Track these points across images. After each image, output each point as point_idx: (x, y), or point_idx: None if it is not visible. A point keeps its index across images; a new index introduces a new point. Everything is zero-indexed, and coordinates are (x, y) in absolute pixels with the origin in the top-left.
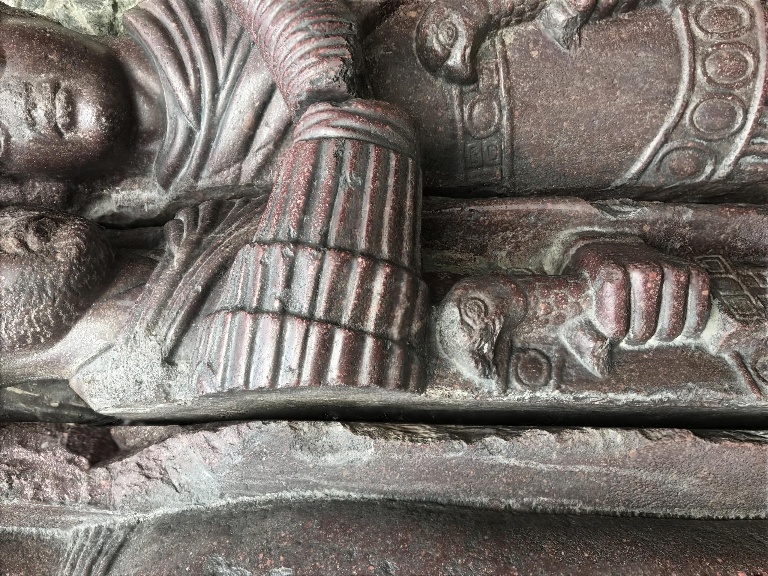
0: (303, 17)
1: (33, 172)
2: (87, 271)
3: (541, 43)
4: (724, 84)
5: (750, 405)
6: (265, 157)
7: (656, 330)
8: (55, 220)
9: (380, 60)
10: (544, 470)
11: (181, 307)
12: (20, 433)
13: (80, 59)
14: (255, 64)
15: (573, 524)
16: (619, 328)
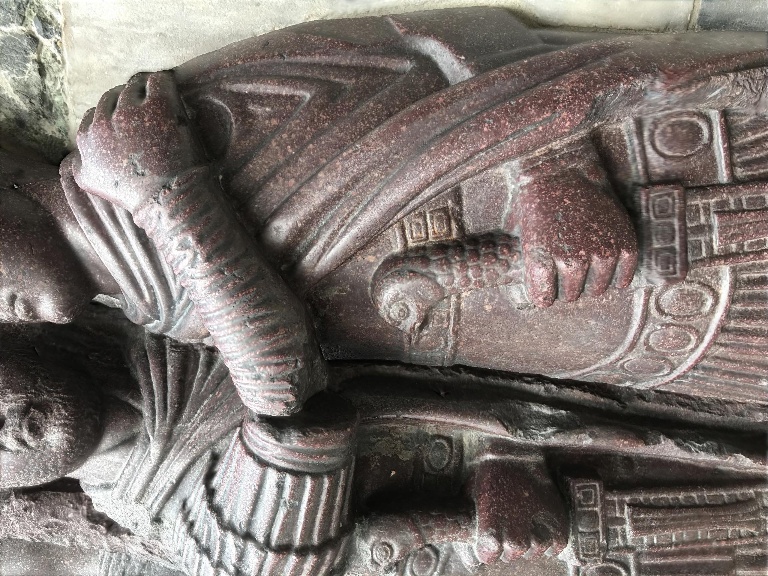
0: (249, 358)
1: None
2: (79, 449)
3: (497, 300)
4: (661, 352)
5: None
6: None
7: None
8: (42, 409)
9: (334, 299)
10: None
11: (161, 491)
12: (50, 506)
13: (29, 266)
14: None
15: None
16: (489, 563)
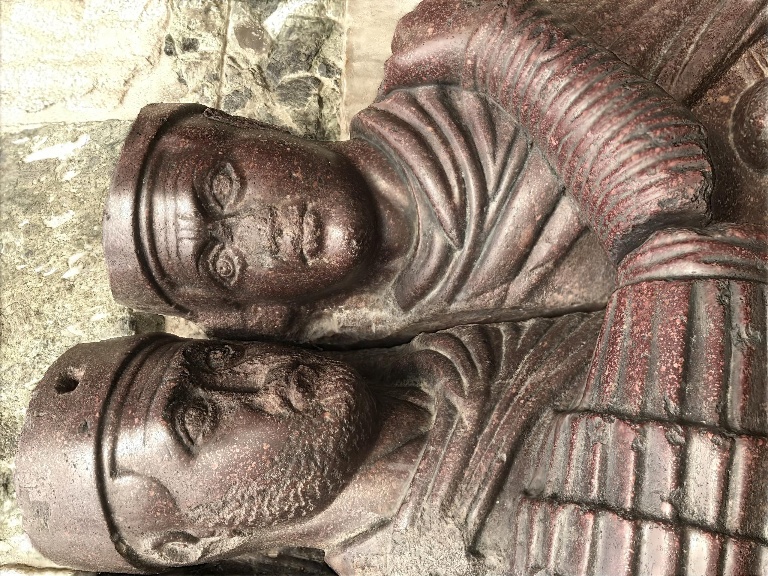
0: (639, 122)
1: (263, 299)
2: (356, 430)
3: None
4: None
5: None
6: (541, 277)
7: None
8: (313, 367)
9: None
10: None
11: (483, 481)
12: None
13: (326, 175)
14: (537, 171)
15: None
16: None
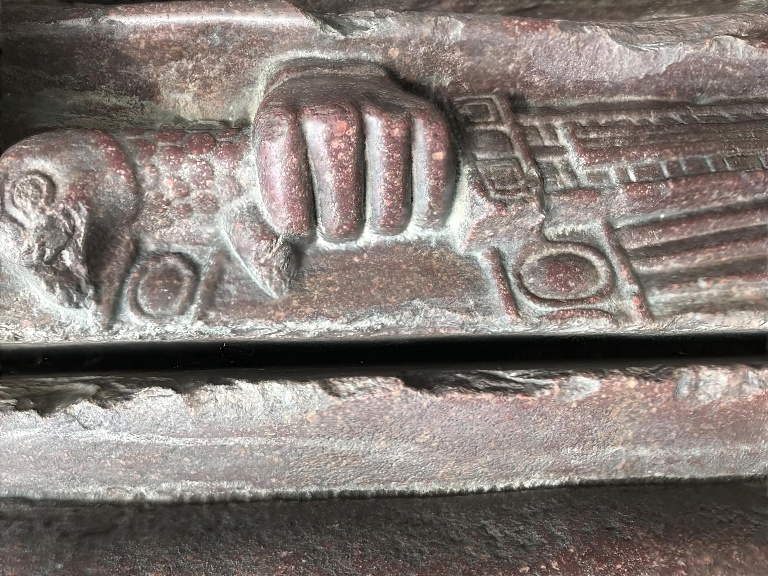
0: None
1: None
2: None
3: None
4: None
5: (505, 330)
6: None
7: (366, 218)
8: None
9: None
10: (180, 446)
11: None
12: None
13: None
14: None
15: (223, 524)
16: (293, 218)
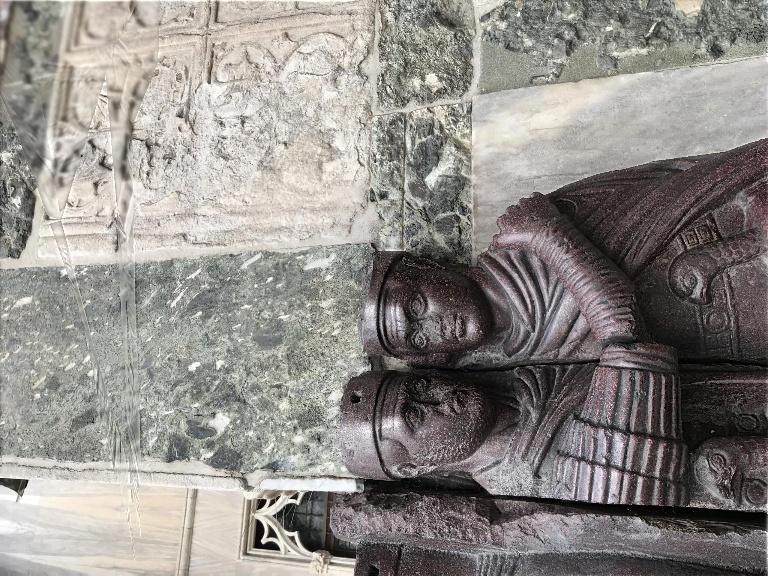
0: (604, 295)
1: None
2: (484, 422)
3: (755, 276)
4: None
5: None
6: (574, 347)
7: None
8: (464, 392)
9: (646, 291)
10: (767, 553)
11: (540, 446)
12: (450, 503)
13: (466, 298)
14: (568, 300)
15: None
16: None
